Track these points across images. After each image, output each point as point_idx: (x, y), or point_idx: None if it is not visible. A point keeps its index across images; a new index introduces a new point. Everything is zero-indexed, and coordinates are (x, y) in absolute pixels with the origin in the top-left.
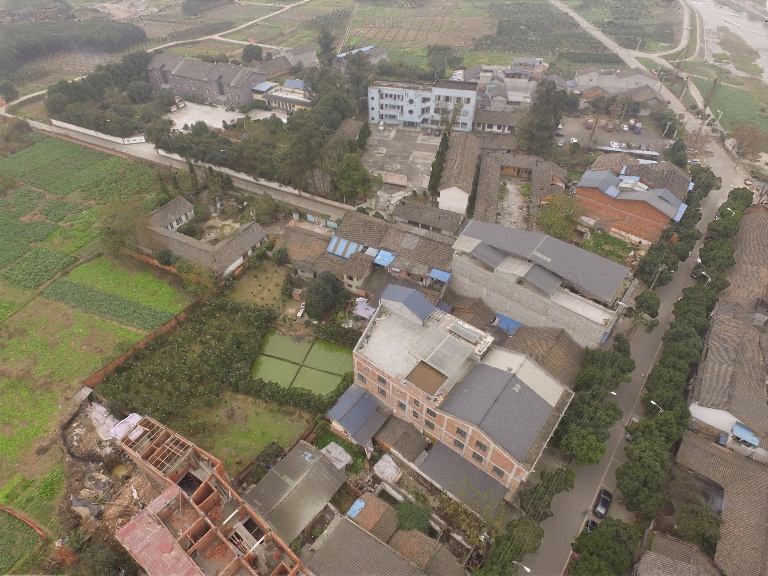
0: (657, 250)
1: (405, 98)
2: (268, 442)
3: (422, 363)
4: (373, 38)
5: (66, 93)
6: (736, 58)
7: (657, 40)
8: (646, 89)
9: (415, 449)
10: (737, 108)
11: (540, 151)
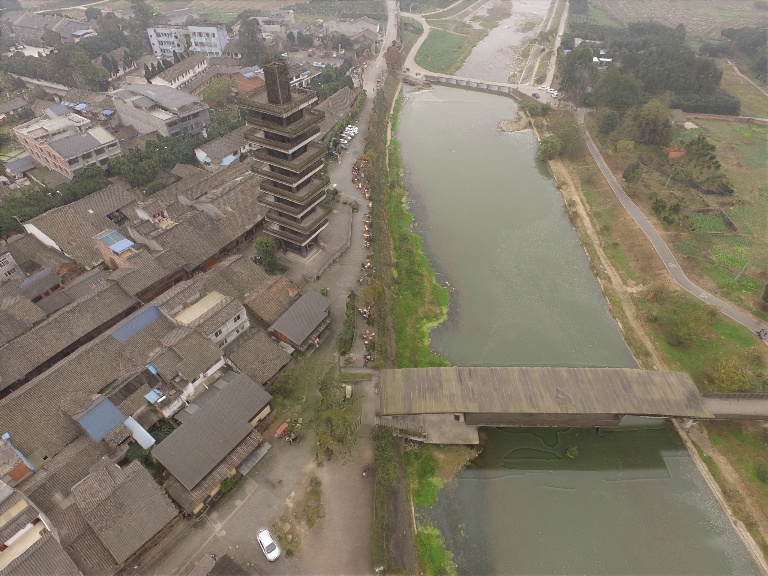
0: None
1: (172, 35)
2: None
3: None
4: (209, 7)
5: None
6: (488, 18)
7: (436, 6)
8: (364, 31)
9: None
10: (442, 46)
11: (252, 66)
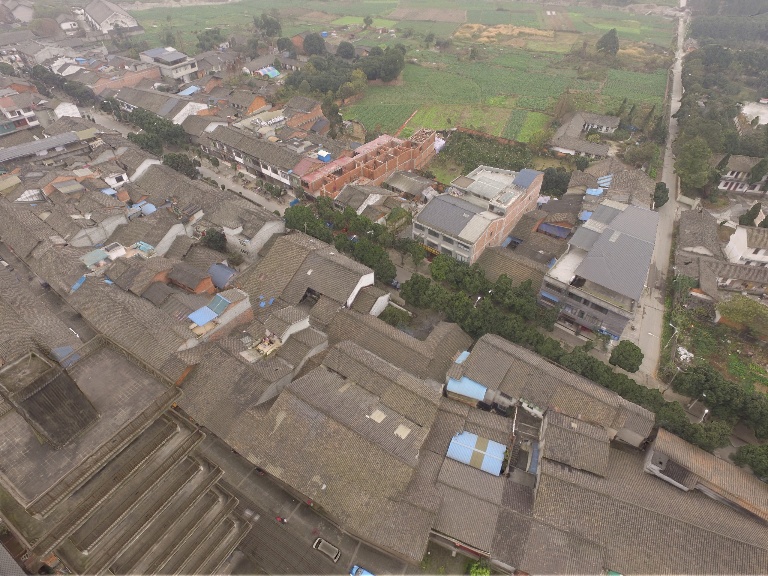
0: (747, 393)
1: None
2: (439, 181)
3: None
4: None
5: (710, 53)
6: None
7: None
8: None
9: None
10: None
11: None
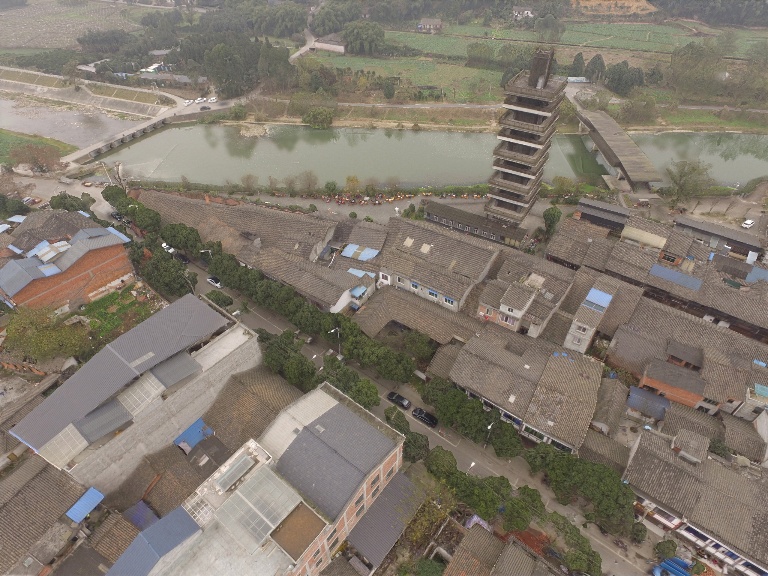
0: (154, 270)
1: None
2: None
3: (273, 535)
4: None
5: None
6: None
7: None
8: None
9: (349, 573)
10: None
11: None
